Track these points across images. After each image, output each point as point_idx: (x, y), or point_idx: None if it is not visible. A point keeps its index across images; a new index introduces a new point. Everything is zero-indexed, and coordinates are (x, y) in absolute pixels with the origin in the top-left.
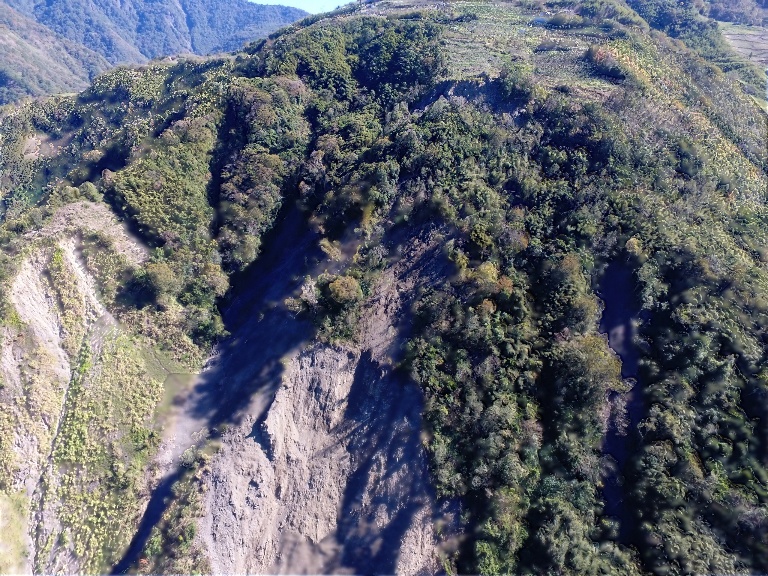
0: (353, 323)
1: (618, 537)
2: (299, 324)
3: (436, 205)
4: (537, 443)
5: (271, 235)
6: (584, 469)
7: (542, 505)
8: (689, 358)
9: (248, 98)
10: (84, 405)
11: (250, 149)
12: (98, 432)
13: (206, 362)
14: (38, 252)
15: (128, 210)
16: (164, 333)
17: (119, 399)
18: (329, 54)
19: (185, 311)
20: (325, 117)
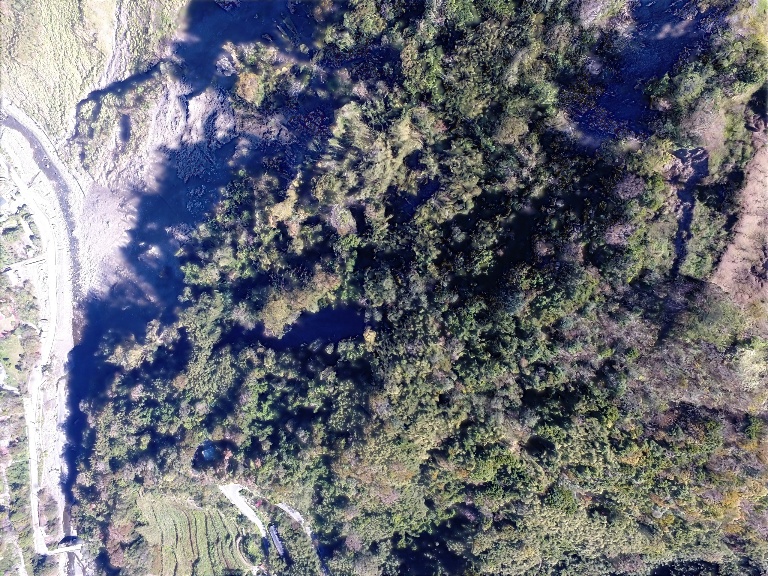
0: None
1: None
2: None
3: None
4: None
5: None
6: None
7: None
8: None
9: None
10: None
11: None
12: None
13: (229, 2)
14: None
15: None
16: None
17: None
18: None
19: None
20: None
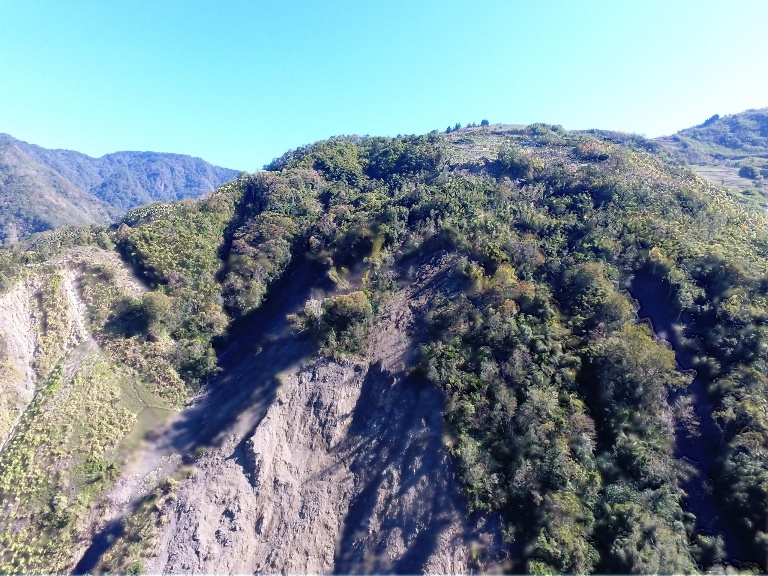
0: (361, 336)
1: (726, 557)
2: (301, 344)
3: (447, 233)
4: (590, 444)
5: (277, 287)
6: (657, 469)
7: (611, 514)
8: (751, 350)
9: (267, 181)
10: (39, 427)
11: (264, 214)
12: (46, 458)
13: (191, 400)
14: (36, 277)
15: (137, 256)
16: (149, 364)
17: (82, 424)
18: (343, 157)
19: (177, 344)
20: (337, 199)
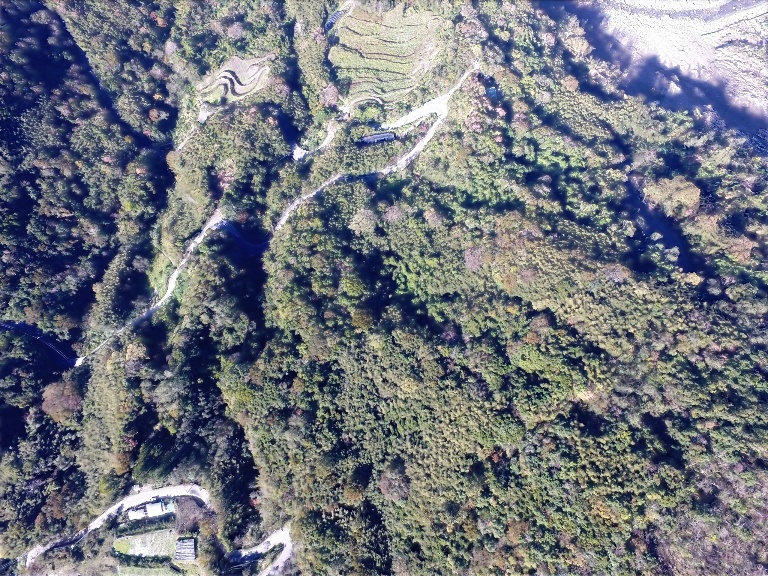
0: None
1: None
2: None
3: None
4: None
5: None
6: None
7: None
8: None
9: None
10: None
11: None
12: None
13: None
14: None
15: None
16: None
17: None
18: None
19: None
20: None
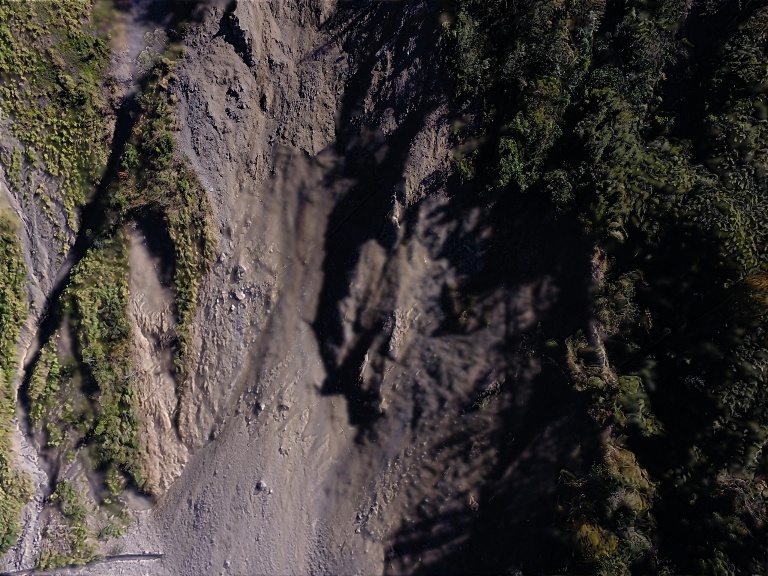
0: None
1: (669, 134)
2: None
3: None
4: (594, 24)
5: None
6: (649, 54)
7: (586, 99)
8: None
9: None
10: None
11: None
12: (25, 35)
13: None
14: None
15: None
16: None
17: None
18: None
19: None
20: None
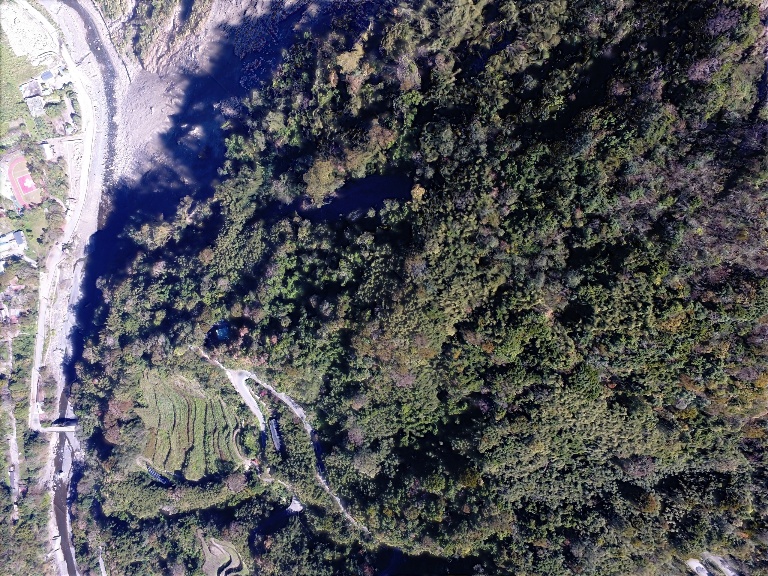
0: None
1: None
2: None
3: None
4: None
5: None
6: None
7: None
8: None
9: None
10: None
11: None
12: None
13: None
14: None
15: None
16: None
17: None
18: None
19: None
20: None
